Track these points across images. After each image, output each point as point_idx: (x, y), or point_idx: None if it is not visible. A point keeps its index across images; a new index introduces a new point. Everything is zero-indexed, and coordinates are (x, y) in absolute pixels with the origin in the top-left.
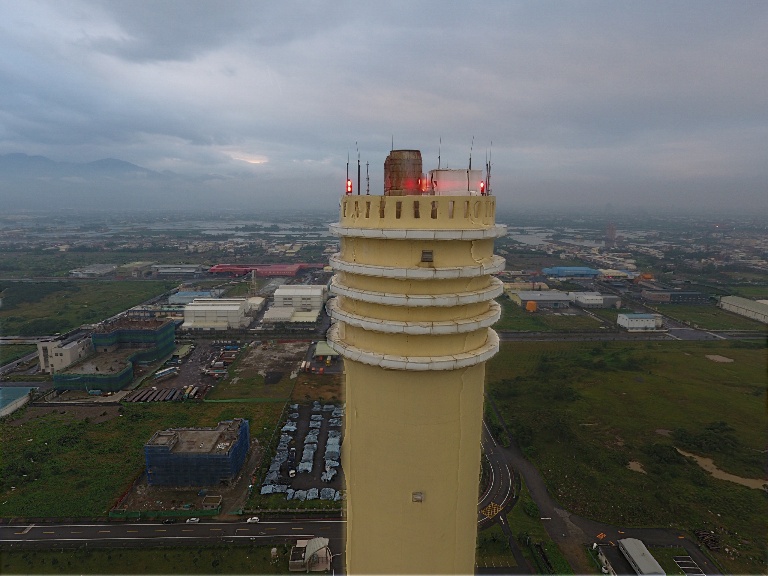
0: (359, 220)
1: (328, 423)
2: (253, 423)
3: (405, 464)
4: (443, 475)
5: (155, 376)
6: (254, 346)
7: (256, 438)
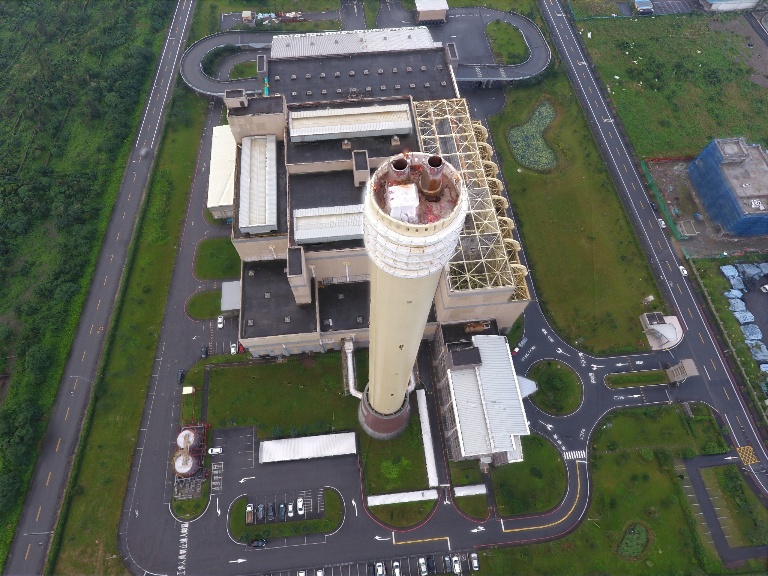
0: None
1: None
2: None
3: None
4: None
5: None
6: None
7: None
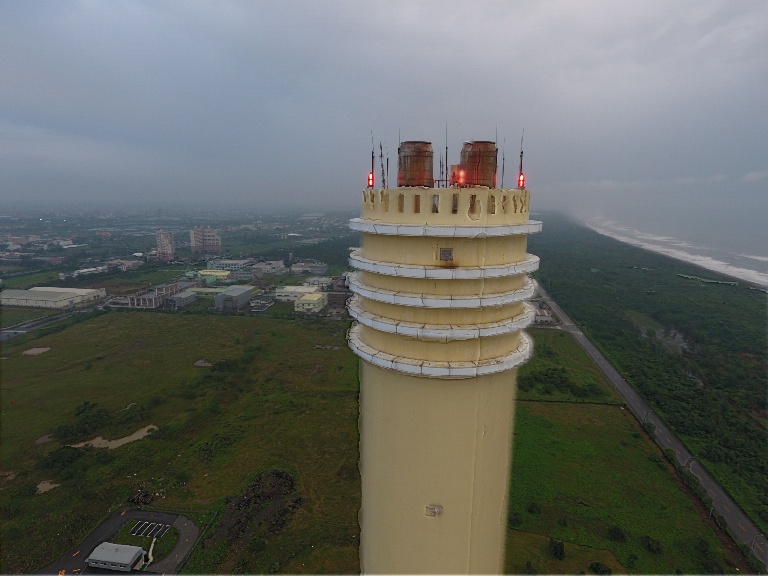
0: (508, 216)
1: None
2: None
3: None
4: None
5: None
6: None
7: None
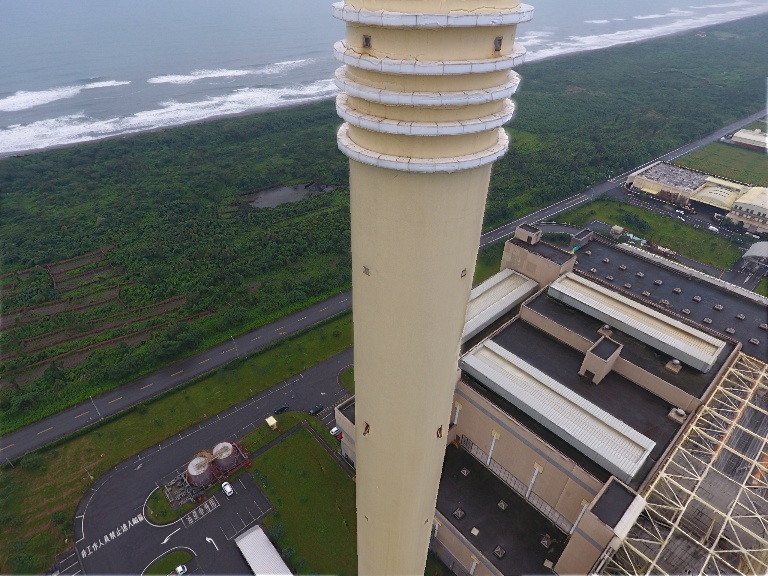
0: None
1: None
2: None
3: None
4: None
5: None
6: None
7: None
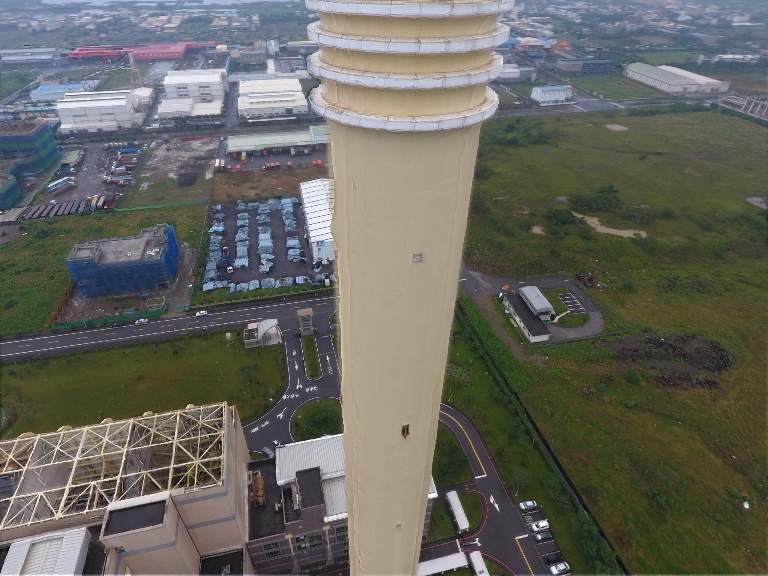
0: None
1: (256, 220)
2: (177, 227)
3: (407, 229)
4: (441, 236)
5: (48, 189)
6: (156, 147)
7: (184, 242)
